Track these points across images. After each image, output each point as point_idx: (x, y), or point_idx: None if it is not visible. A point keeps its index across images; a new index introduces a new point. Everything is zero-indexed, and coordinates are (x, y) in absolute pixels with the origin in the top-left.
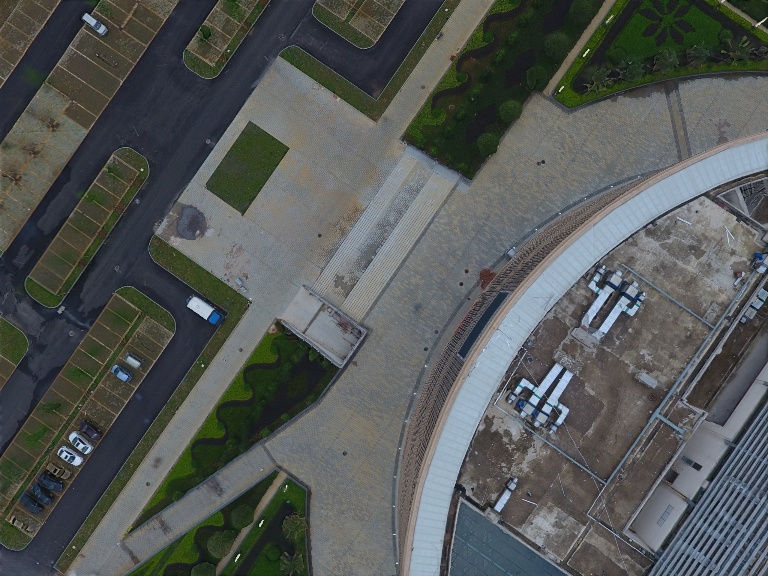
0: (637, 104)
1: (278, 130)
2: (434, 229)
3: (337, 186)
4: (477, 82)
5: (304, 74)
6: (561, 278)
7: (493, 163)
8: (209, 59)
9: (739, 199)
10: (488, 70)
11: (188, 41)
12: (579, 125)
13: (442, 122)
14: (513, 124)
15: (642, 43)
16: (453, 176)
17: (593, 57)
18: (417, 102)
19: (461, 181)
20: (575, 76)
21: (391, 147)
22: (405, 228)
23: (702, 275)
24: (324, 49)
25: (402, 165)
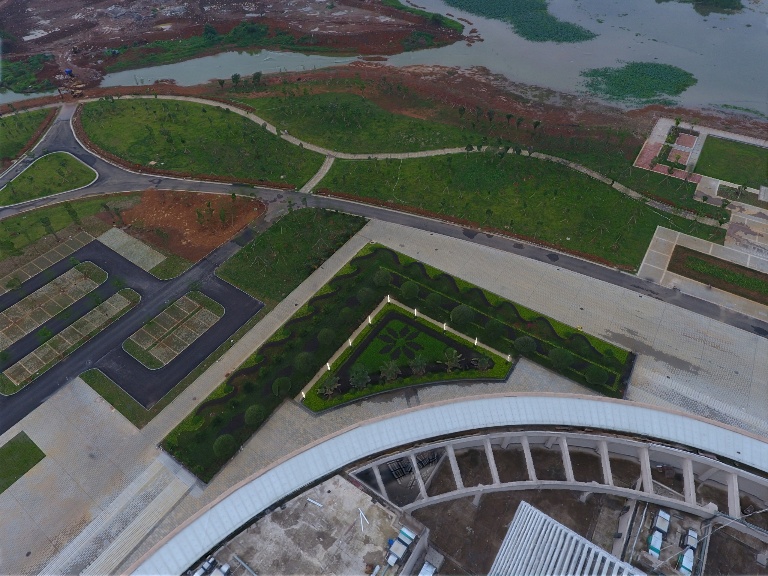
0: (380, 408)
1: (44, 439)
2: (151, 541)
3: (75, 494)
4: (241, 393)
5: (93, 390)
6: (157, 575)
7: (234, 465)
8: (17, 380)
9: (376, 478)
10: (245, 382)
11: (8, 367)
12: (324, 427)
13: (199, 428)
14: (261, 427)
15: (379, 359)
16: (190, 480)
17: (339, 370)
18: (185, 411)
19: (196, 485)
20: (323, 385)
21: (146, 453)
22: (122, 541)
23: (329, 571)
24: (120, 370)
25: (149, 470)
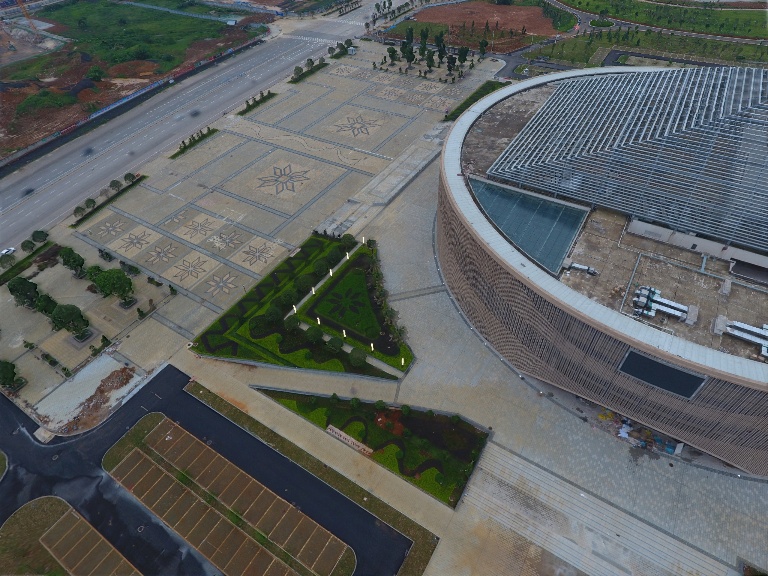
0: None
1: None
2: None
3: None
4: None
5: None
6: None
7: None
8: None
9: None
10: None
11: None
12: None
13: None
14: None
15: None
16: None
17: None
18: None
19: None
20: None
21: None
22: None
23: None
24: None
25: None
